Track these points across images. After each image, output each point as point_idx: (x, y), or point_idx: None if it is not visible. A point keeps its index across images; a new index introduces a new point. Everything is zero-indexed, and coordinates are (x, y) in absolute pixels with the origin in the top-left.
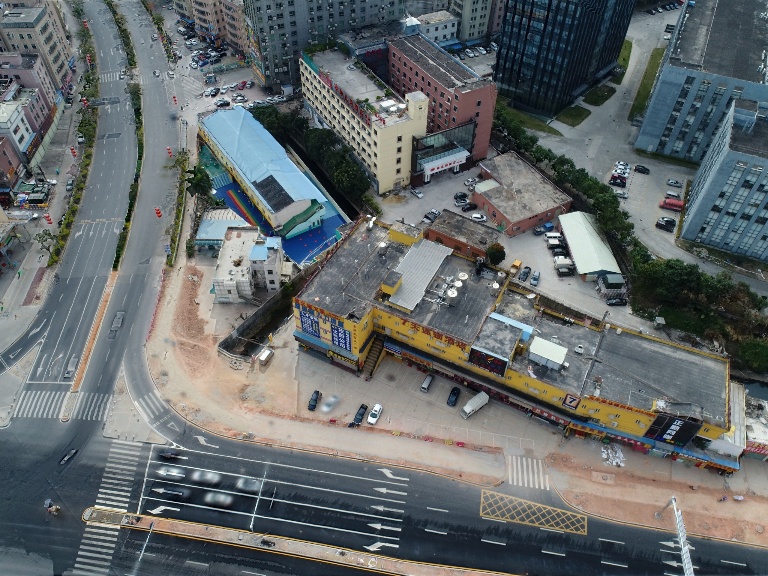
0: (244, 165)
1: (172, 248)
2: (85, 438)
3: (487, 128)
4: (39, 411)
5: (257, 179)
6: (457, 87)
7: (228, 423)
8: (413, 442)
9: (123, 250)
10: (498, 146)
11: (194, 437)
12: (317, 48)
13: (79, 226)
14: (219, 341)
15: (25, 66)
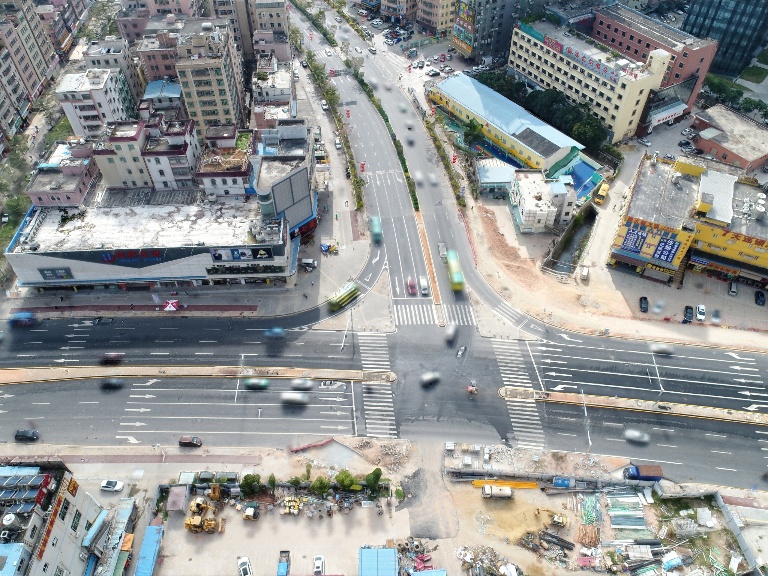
0: (497, 121)
1: (459, 191)
2: (467, 338)
3: (699, 84)
4: (417, 319)
5: (515, 132)
6: (686, 45)
7: (581, 323)
8: (744, 332)
9: (416, 195)
10: (697, 102)
11: (557, 335)
12: (529, 19)
13: (364, 177)
14: (537, 263)
15: (278, 42)
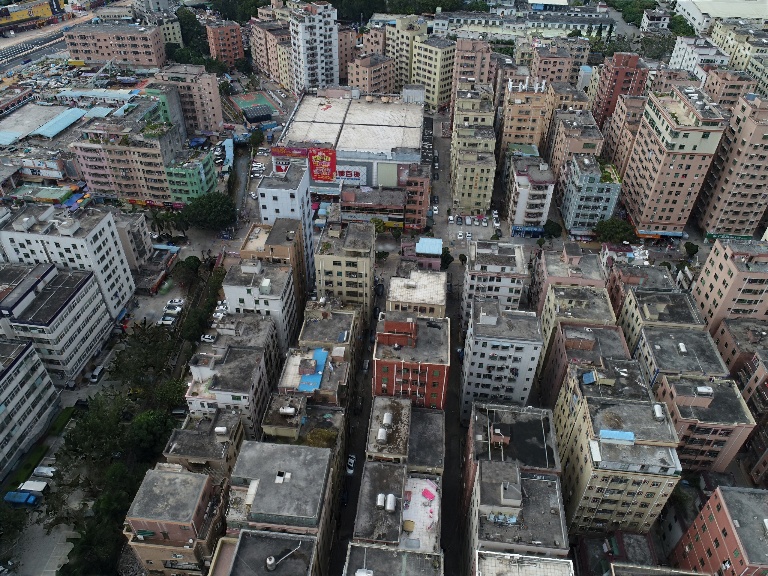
0: None
1: None
2: None
3: None
4: None
5: None
6: None
7: None
8: None
9: None
10: None
11: None
12: None
13: None
14: None
15: None
